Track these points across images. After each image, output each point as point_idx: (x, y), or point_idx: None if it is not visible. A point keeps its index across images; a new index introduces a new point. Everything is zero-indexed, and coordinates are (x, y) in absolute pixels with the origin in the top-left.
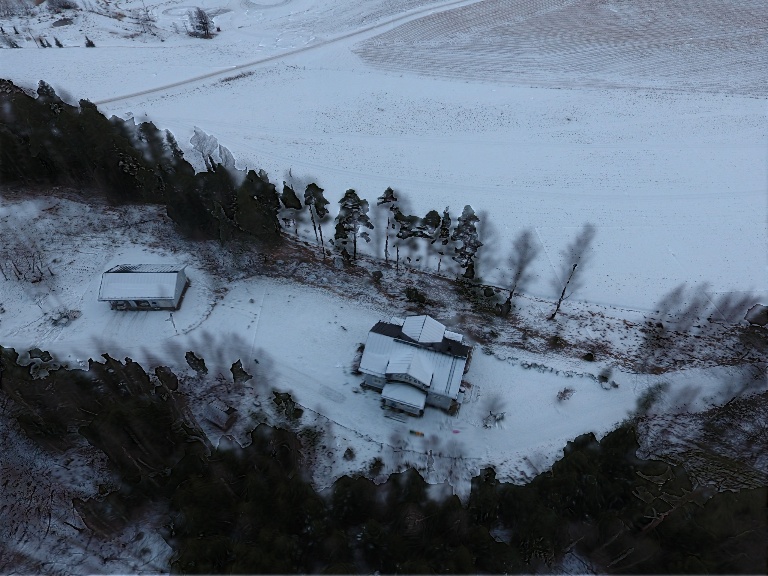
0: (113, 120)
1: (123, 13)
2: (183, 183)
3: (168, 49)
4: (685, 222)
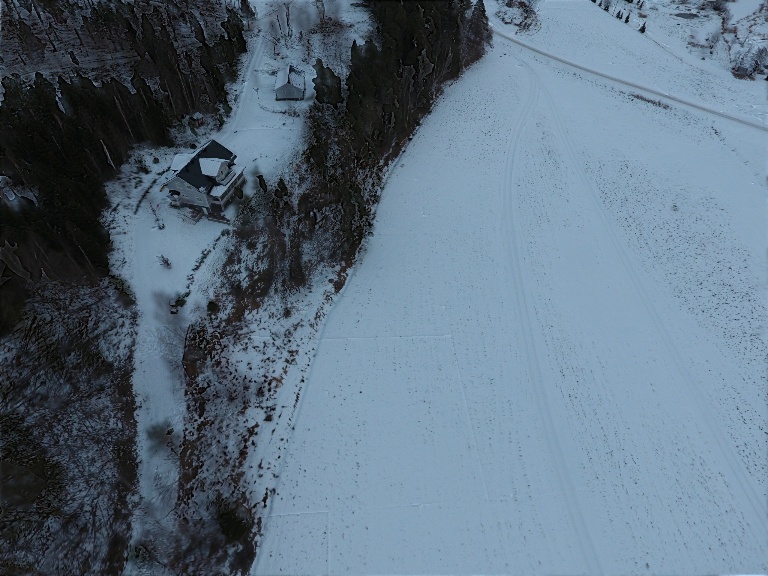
0: (410, 21)
1: (739, 30)
2: (352, 57)
3: (676, 61)
4: (515, 570)
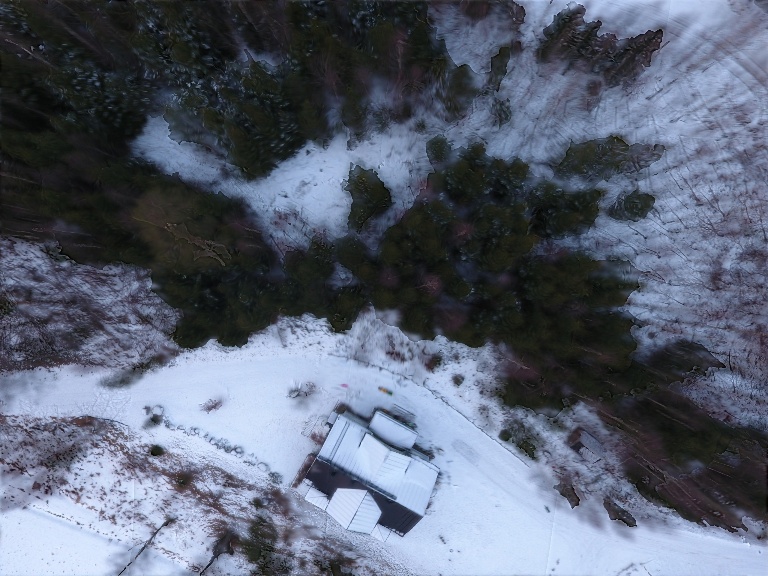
0: None
1: None
2: None
3: None
4: None
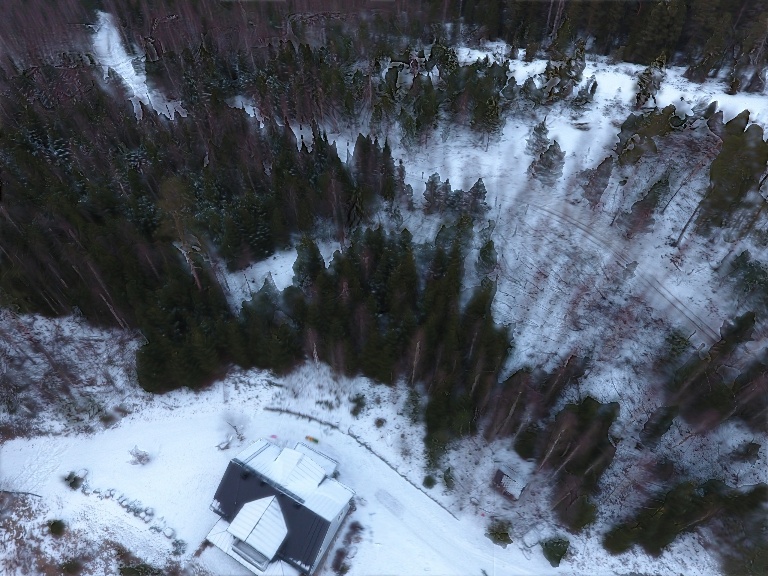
0: None
1: None
2: None
3: None
4: None
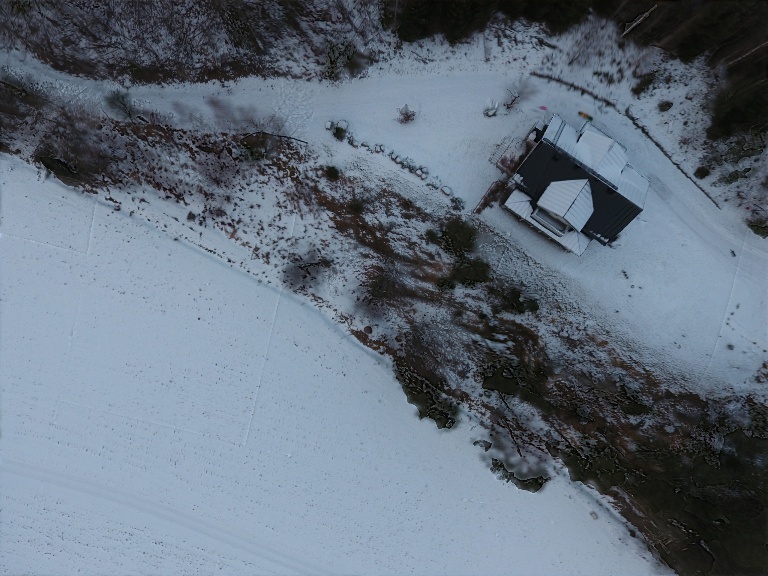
0: None
1: None
2: None
3: None
4: None
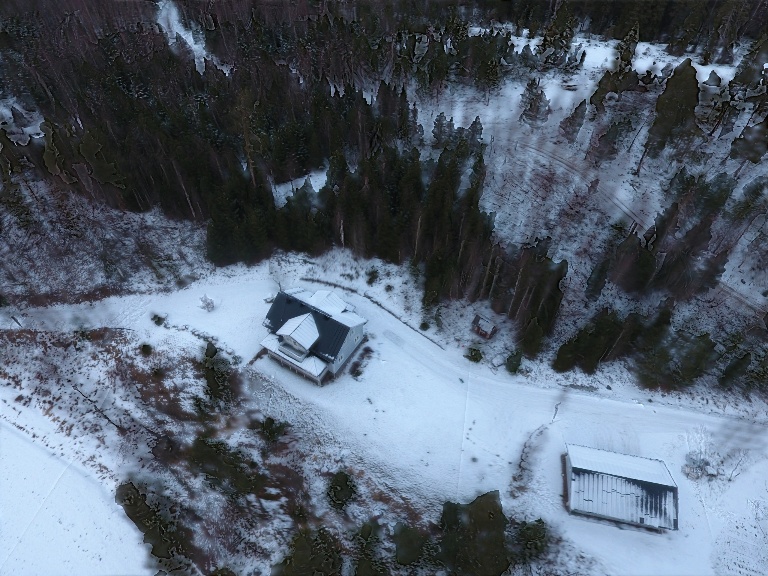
0: None
1: None
2: None
3: None
4: None
